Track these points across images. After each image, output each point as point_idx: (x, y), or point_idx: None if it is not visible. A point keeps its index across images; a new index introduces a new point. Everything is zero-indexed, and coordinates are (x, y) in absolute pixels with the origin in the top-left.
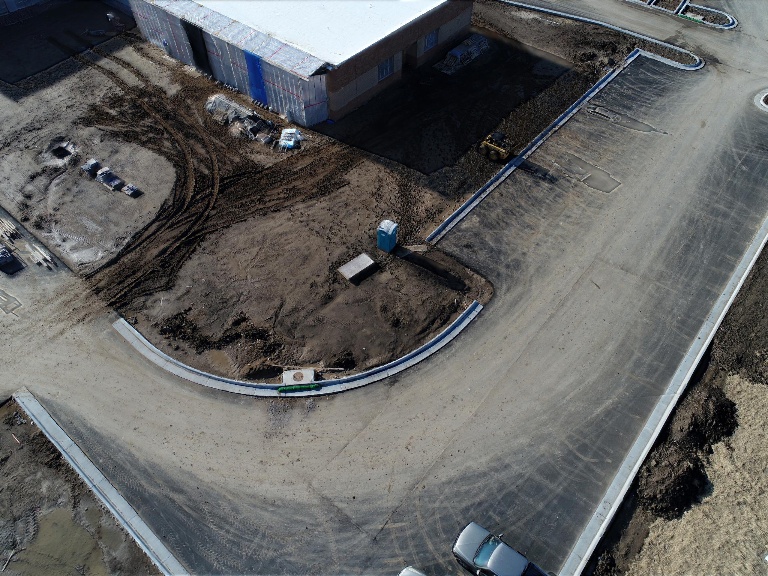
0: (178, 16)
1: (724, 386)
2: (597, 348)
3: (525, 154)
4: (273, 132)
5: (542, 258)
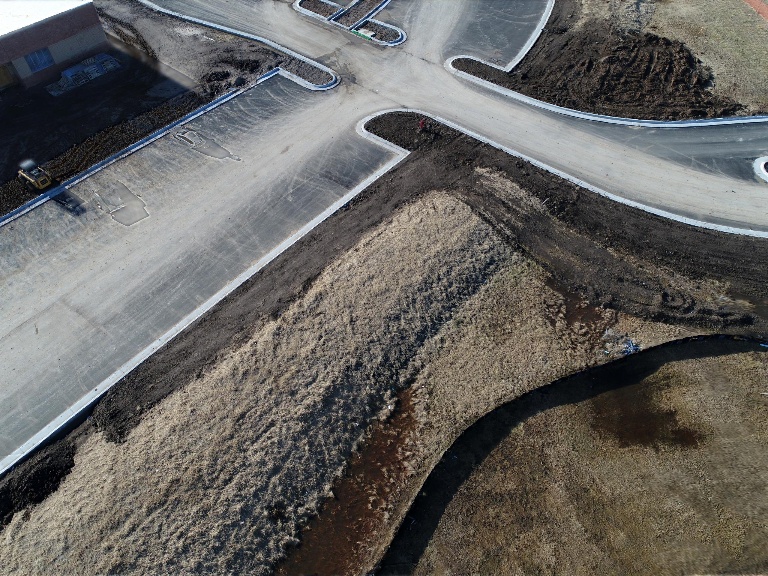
0: None
1: (82, 444)
2: None
3: (70, 183)
4: None
5: (3, 299)
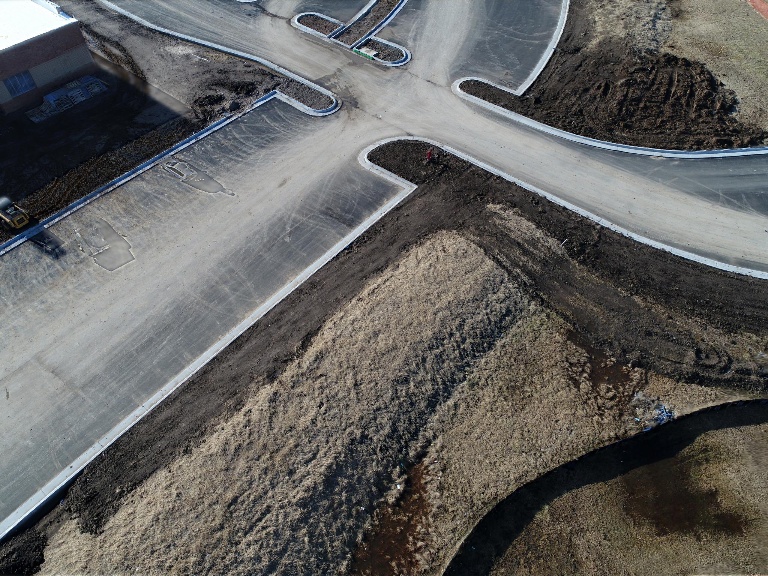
0: None
1: (54, 534)
2: None
3: (49, 222)
4: None
5: None
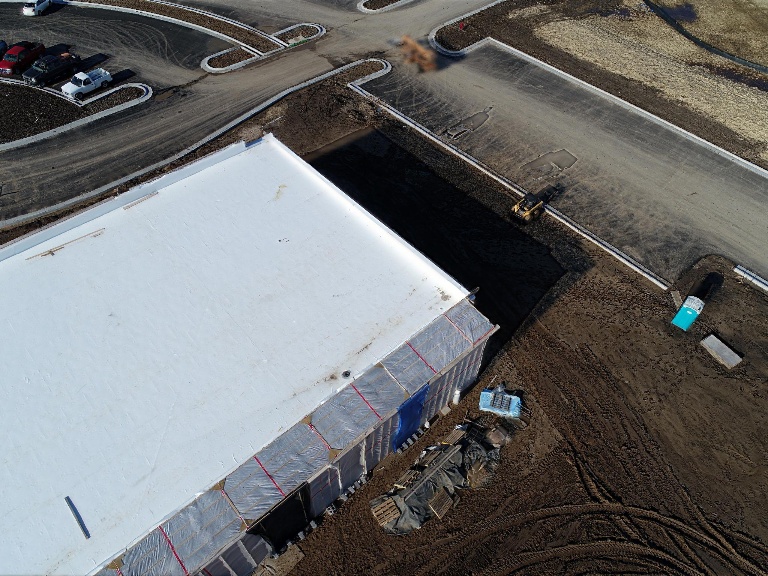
0: (239, 536)
1: None
2: (760, 210)
3: None
4: (482, 424)
5: (669, 217)
